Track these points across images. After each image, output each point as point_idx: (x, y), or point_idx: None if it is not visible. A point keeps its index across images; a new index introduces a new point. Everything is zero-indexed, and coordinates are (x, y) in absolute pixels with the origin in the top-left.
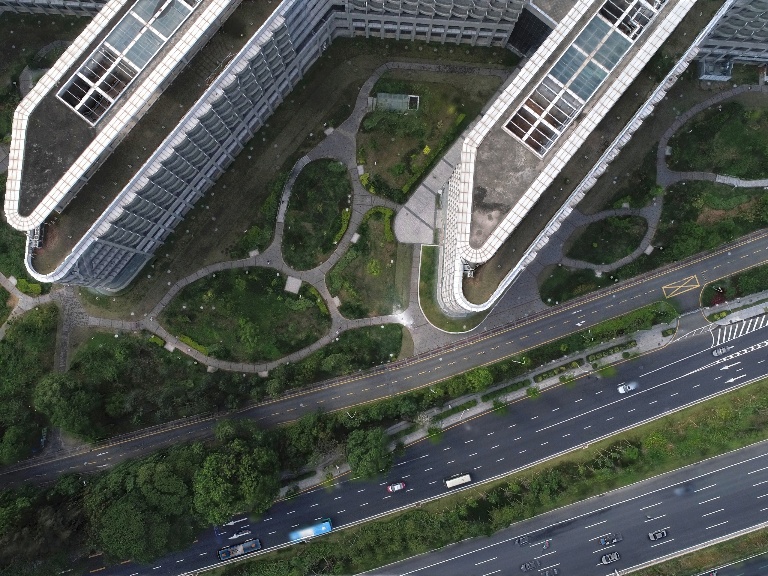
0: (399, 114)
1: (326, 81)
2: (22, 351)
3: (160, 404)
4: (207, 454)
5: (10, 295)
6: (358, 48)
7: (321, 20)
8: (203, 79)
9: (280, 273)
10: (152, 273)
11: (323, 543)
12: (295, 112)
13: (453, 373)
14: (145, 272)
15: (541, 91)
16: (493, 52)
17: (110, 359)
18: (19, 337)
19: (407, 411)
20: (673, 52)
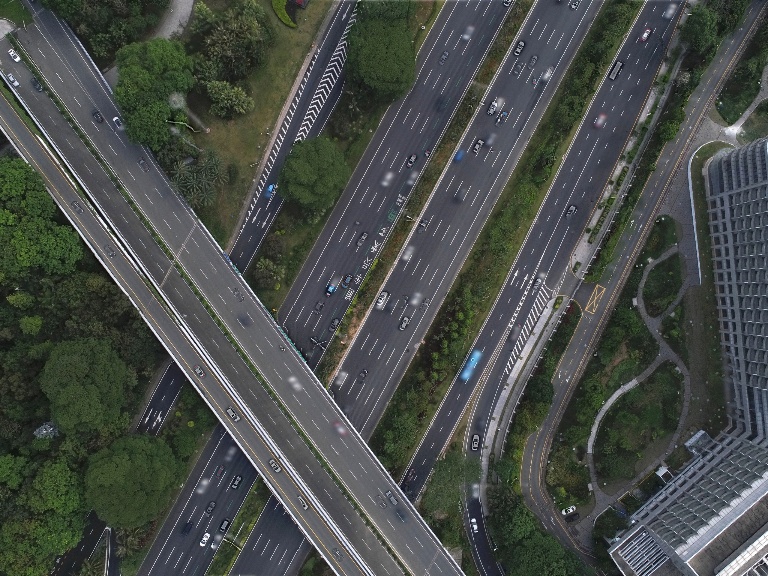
0: None
1: None
2: None
3: None
4: None
5: None
6: None
7: None
8: None
9: None
10: None
11: None
12: None
13: None
14: None
15: None
16: None
17: None
18: None
19: None
20: None
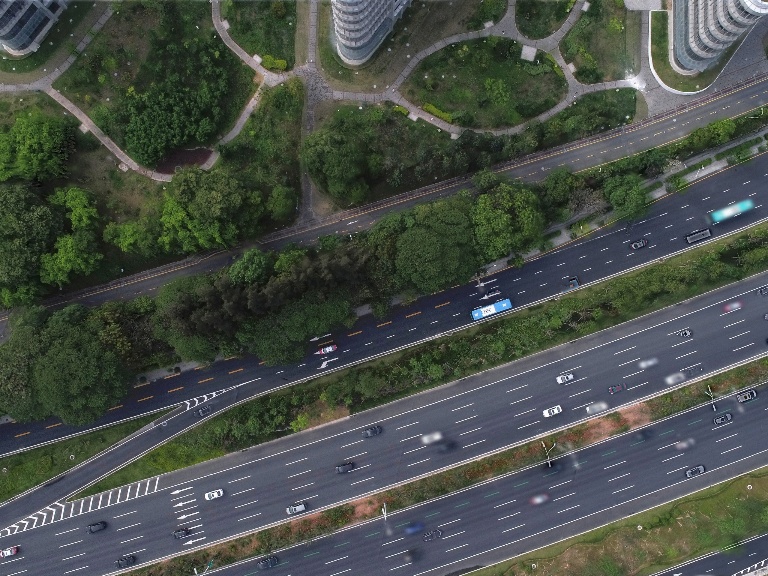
0: None
1: None
2: (272, 124)
3: (421, 157)
4: (477, 195)
5: (255, 72)
6: None
7: None
8: None
9: (516, 42)
10: (392, 46)
11: (573, 299)
12: None
13: (687, 133)
14: (385, 46)
15: None
16: None
17: (358, 128)
18: (268, 111)
19: (656, 160)
20: None
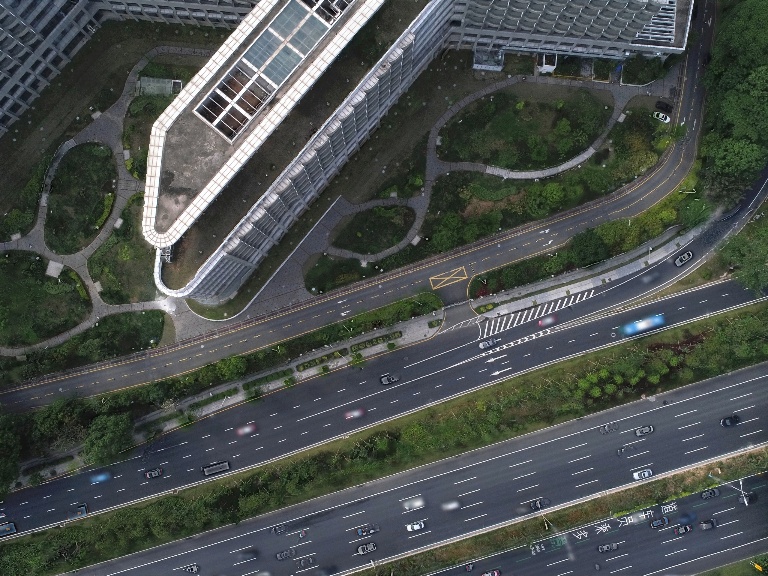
0: None
1: (95, 64)
2: None
3: None
4: None
5: None
6: (127, 31)
7: (69, 2)
8: None
9: (41, 257)
10: None
11: (77, 528)
12: (62, 95)
13: (214, 361)
14: None
15: (235, 75)
16: None
17: None
18: None
19: (155, 397)
20: (387, 38)
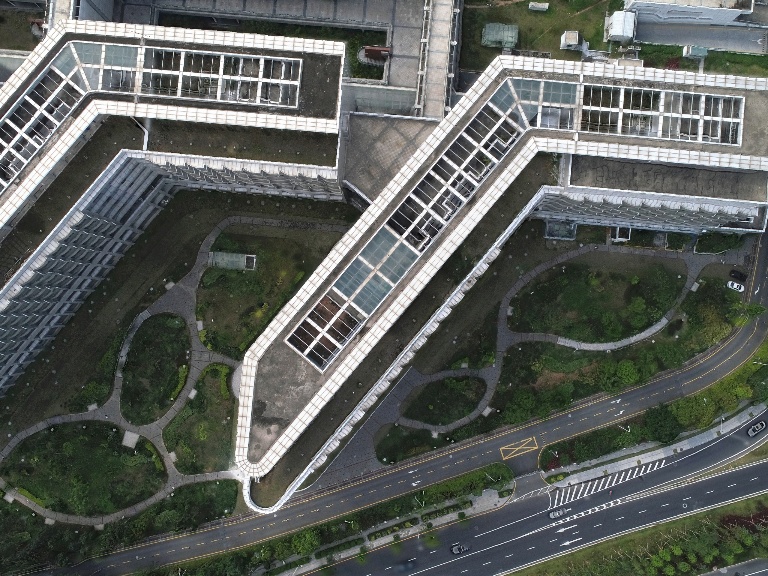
0: (238, 271)
1: (168, 235)
2: None
3: None
4: None
5: None
6: (200, 202)
7: (148, 189)
8: (1, 275)
9: (118, 428)
10: None
11: None
12: (136, 266)
13: (287, 530)
14: None
15: (325, 303)
16: (335, 208)
17: None
18: None
19: (232, 574)
20: (473, 253)
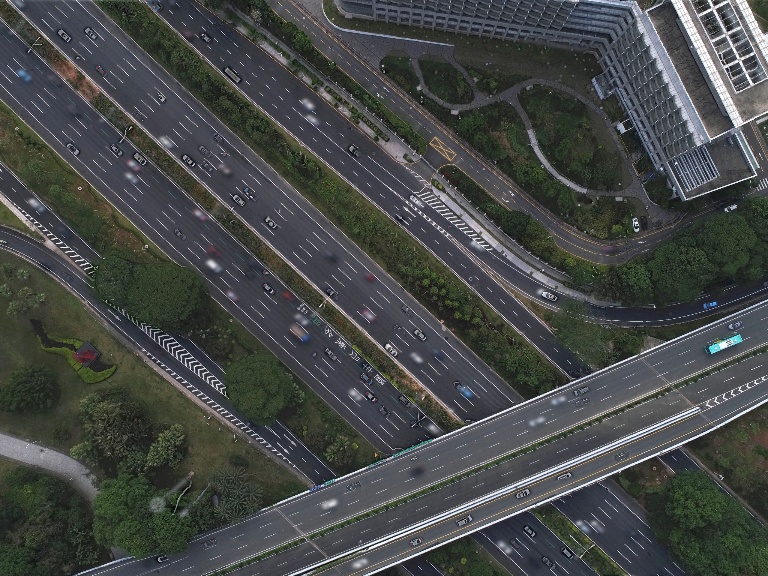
0: None
1: None
2: None
3: None
4: None
5: None
6: None
7: None
8: None
9: None
10: None
11: (145, 11)
12: None
13: None
14: None
15: None
16: None
17: None
18: None
19: (256, 3)
20: None
